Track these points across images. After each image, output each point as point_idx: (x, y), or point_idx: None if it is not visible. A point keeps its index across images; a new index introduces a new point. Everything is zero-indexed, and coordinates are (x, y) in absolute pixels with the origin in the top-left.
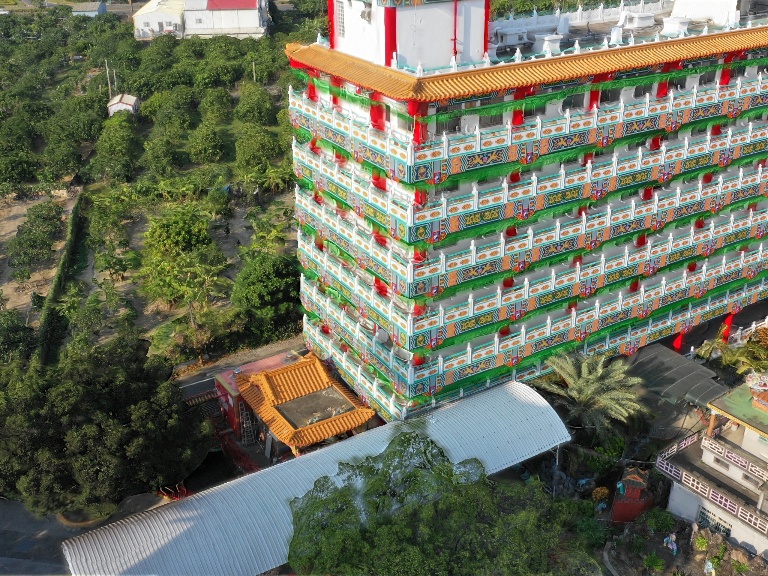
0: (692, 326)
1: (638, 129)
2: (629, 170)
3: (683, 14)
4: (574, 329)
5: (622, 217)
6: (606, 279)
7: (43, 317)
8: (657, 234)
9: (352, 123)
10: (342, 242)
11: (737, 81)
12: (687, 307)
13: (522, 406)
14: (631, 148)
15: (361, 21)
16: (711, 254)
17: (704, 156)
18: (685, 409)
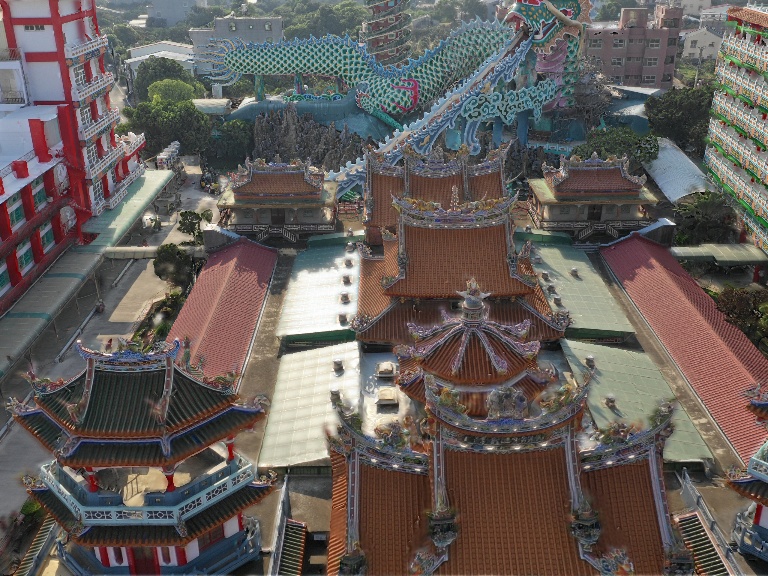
0: None
1: None
2: None
3: None
4: None
5: None
6: None
7: None
8: None
9: None
10: None
11: None
12: None
13: (694, 188)
14: None
15: None
16: None
17: None
18: None
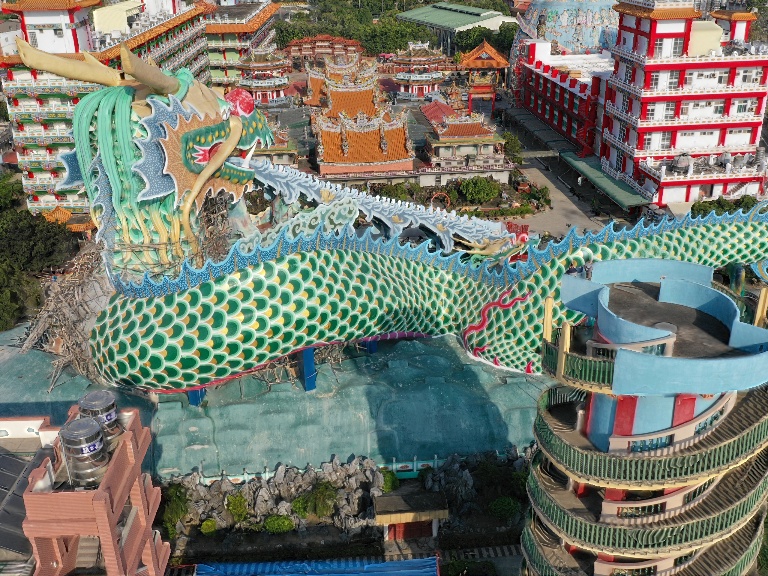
0: None
1: None
2: None
3: (102, 31)
4: None
5: None
6: None
7: None
8: None
9: (65, 80)
10: (64, 139)
11: None
12: None
13: None
14: None
15: (52, 38)
16: None
17: None
18: None
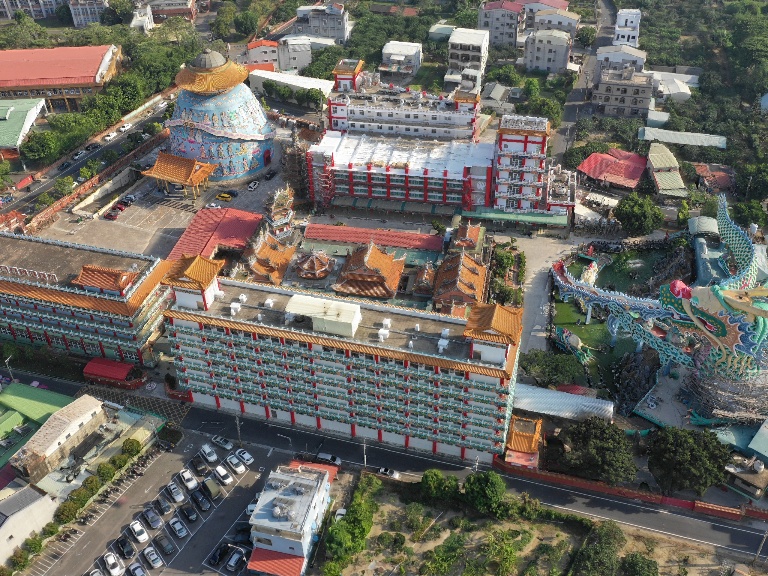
0: None
1: None
2: None
3: None
4: None
5: None
6: None
7: (570, 574)
8: None
9: None
10: None
11: None
12: None
13: None
14: None
15: None
16: None
17: None
18: None
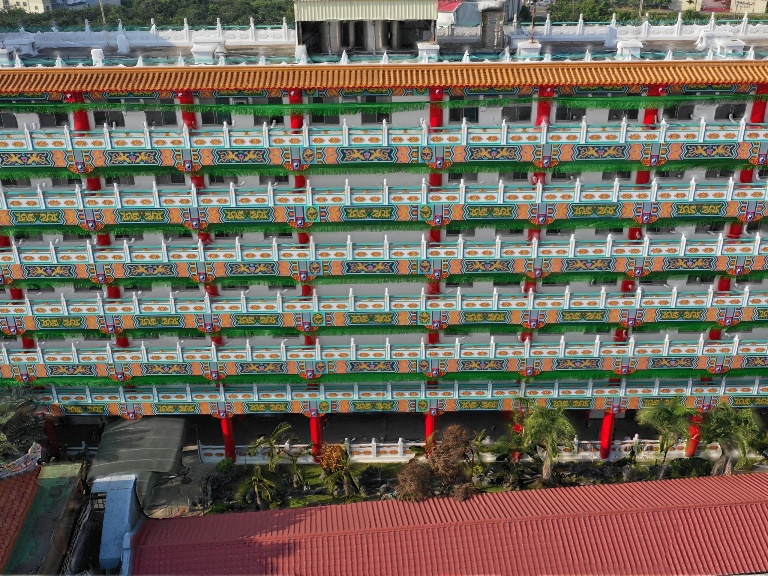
0: (232, 413)
1: (21, 162)
2: (28, 207)
3: None
4: (9, 366)
5: (39, 258)
6: (39, 322)
7: None
8: (140, 291)
9: None
10: None
11: (184, 128)
12: (218, 388)
13: None
14: (58, 184)
15: None
16: (219, 332)
17: (152, 210)
18: (174, 501)
